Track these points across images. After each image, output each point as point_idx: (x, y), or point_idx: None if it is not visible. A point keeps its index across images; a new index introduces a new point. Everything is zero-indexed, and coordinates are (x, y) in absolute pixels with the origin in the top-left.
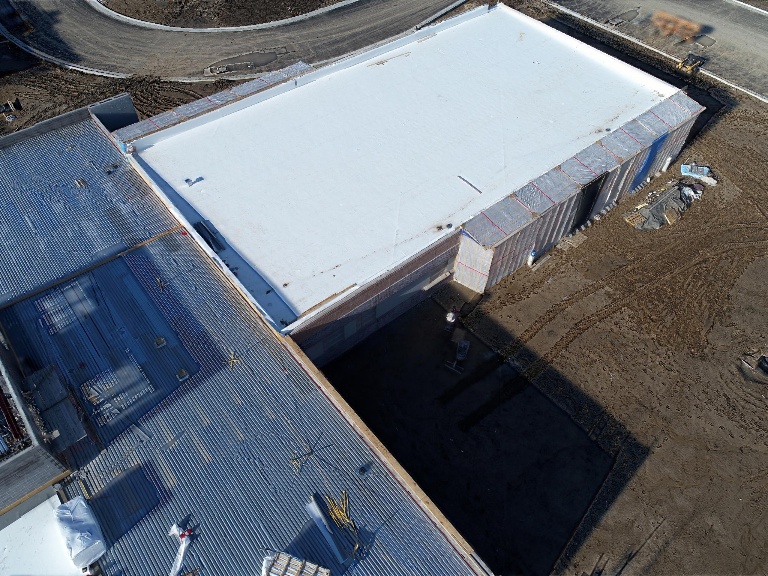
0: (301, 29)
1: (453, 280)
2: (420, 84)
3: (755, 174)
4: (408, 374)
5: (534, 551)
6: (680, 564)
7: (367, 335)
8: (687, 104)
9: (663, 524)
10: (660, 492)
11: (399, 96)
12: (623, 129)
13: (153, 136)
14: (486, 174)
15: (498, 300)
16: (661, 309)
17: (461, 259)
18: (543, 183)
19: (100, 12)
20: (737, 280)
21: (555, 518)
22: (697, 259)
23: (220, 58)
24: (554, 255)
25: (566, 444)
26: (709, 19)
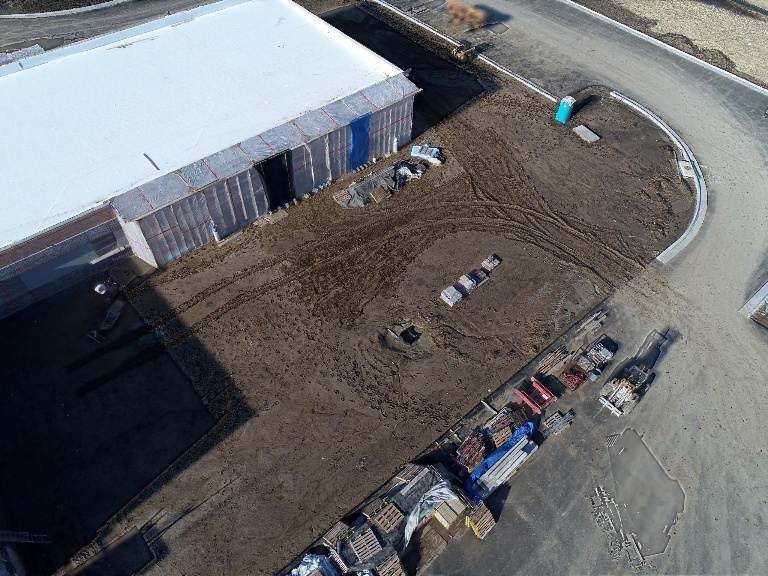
0: (100, 16)
1: (134, 255)
2: (152, 66)
3: (485, 155)
4: (48, 343)
5: (94, 507)
6: (233, 518)
7: (23, 307)
8: (402, 86)
9: (235, 481)
10: (247, 452)
11: (125, 78)
12: (323, 109)
13: None
14: (173, 152)
15: (171, 274)
16: (331, 282)
17: (127, 233)
18: (214, 160)
19: None
20: (419, 255)
21: (130, 476)
22: (389, 235)
23: (5, 44)
24: (247, 231)
25: (175, 408)
26: (512, 7)
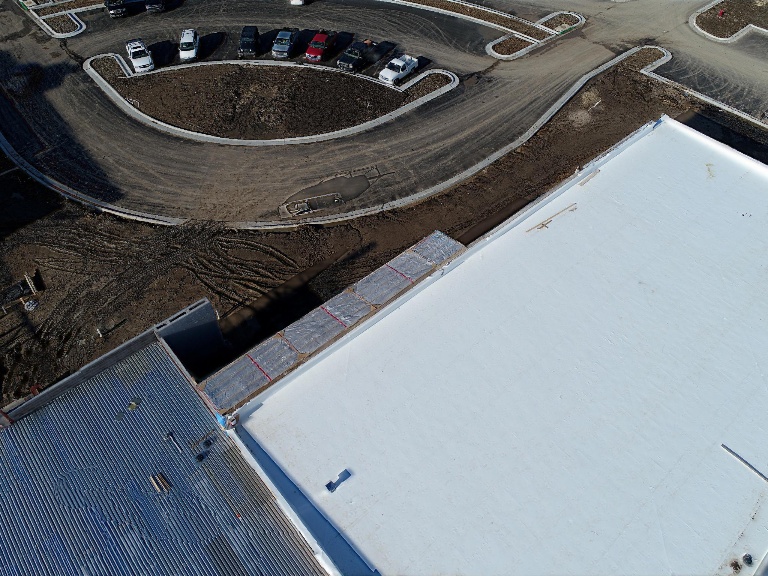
0: (389, 137)
1: None
2: (607, 262)
3: None
4: None
5: None
6: None
7: None
8: None
9: None
10: None
11: (586, 286)
12: None
13: (263, 395)
14: (760, 438)
15: None
16: None
17: None
18: None
19: (131, 117)
20: None
21: None
22: None
23: (296, 188)
24: None
25: None
26: None
